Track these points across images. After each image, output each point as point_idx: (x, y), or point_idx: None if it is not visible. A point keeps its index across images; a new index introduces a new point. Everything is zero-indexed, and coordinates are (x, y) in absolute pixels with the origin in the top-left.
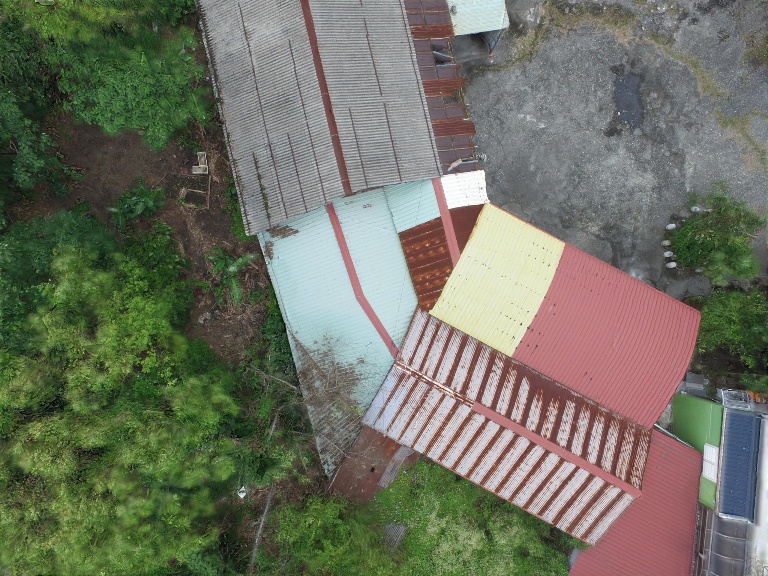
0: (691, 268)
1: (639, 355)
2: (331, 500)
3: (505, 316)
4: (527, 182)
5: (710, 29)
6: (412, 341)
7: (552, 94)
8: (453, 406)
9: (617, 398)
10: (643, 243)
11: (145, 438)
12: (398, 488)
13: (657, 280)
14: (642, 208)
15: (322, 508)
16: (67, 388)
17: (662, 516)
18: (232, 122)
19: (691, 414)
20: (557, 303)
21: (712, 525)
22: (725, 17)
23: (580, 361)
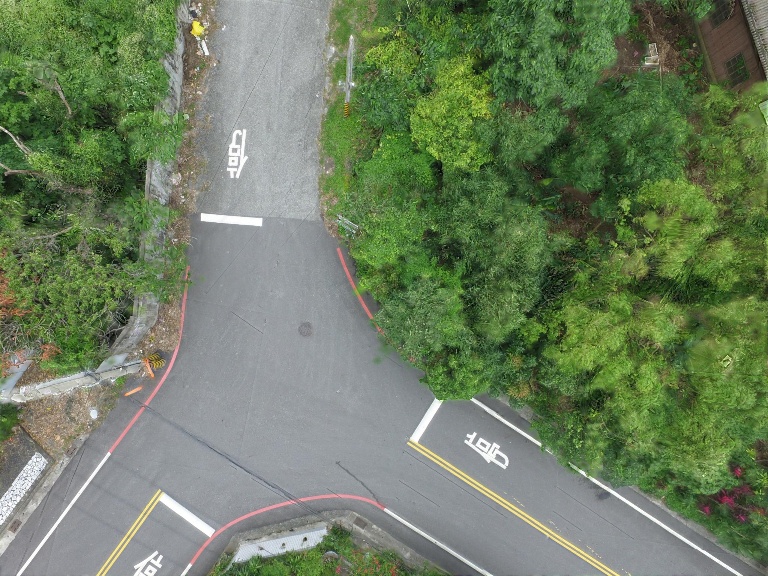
0: None
1: None
2: None
3: None
4: None
5: None
6: None
7: None
8: None
9: None
10: None
11: None
12: None
13: None
14: None
15: None
16: None
17: None
18: None
19: None
20: None
21: None
22: None
23: None
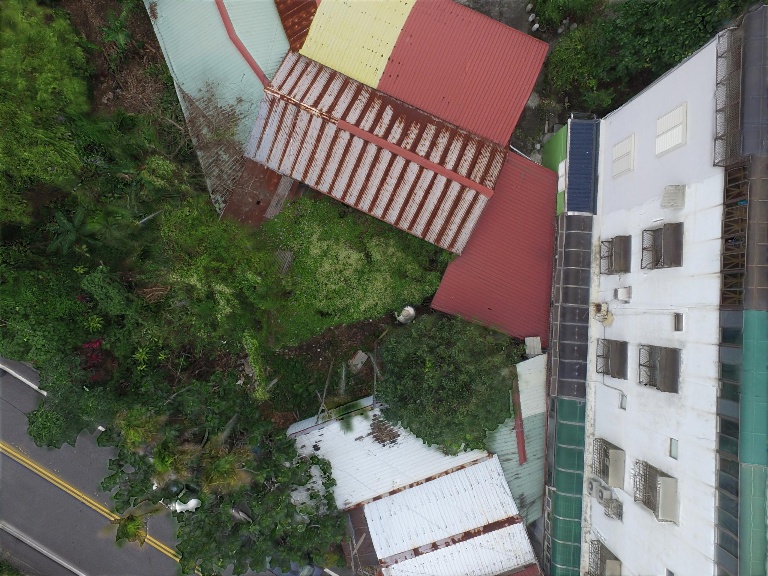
0: (553, 28)
1: (490, 77)
2: None
3: (367, 49)
4: None
5: None
6: (282, 73)
7: None
8: (321, 126)
9: (473, 119)
10: (509, 11)
11: (46, 177)
12: (283, 219)
13: None
14: None
15: None
16: None
17: (524, 231)
18: None
19: (552, 149)
20: (413, 34)
21: (564, 228)
22: None
23: (437, 86)
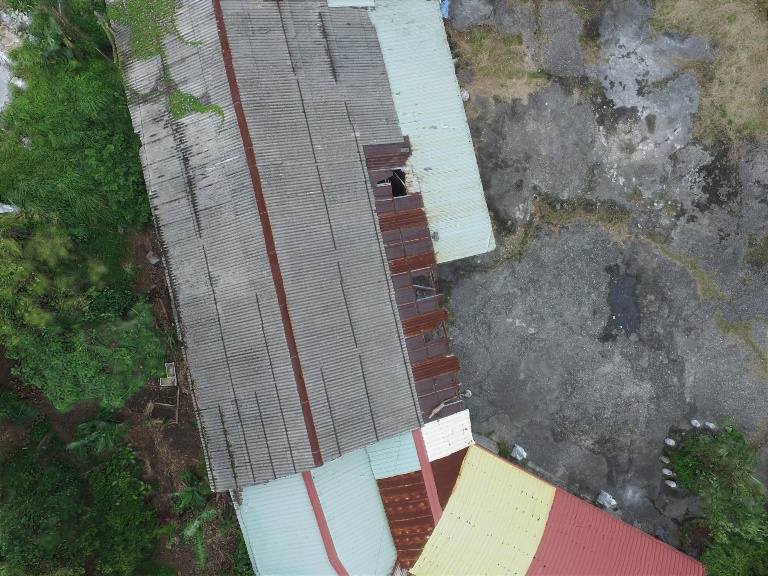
0: (692, 488)
1: None
2: None
3: None
4: (516, 392)
5: (710, 227)
6: None
7: (543, 297)
8: None
9: None
10: (640, 457)
11: None
12: None
13: (655, 497)
14: (639, 420)
15: None
16: None
17: None
18: (196, 369)
19: None
20: (547, 564)
21: None
22: (726, 214)
23: None
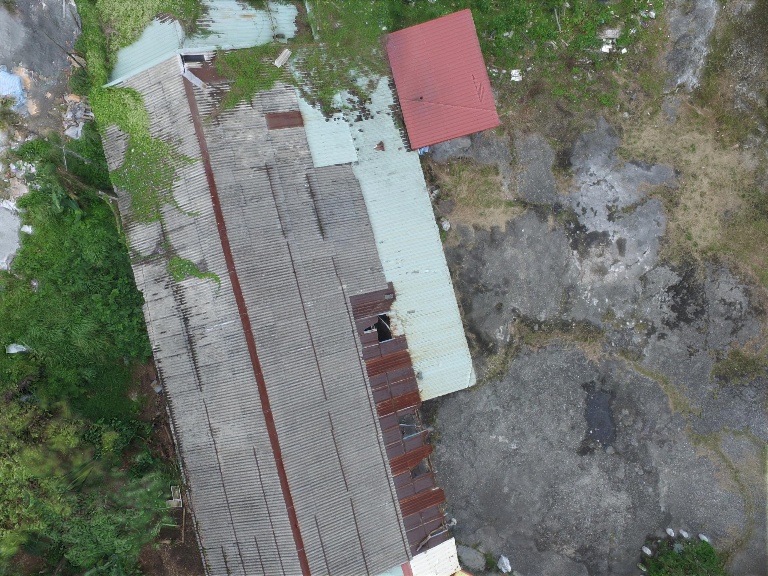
0: None
1: None
2: None
3: None
4: (501, 504)
5: (680, 344)
6: None
7: (524, 414)
8: None
9: None
10: (619, 564)
11: None
12: None
13: None
14: (617, 529)
15: None
16: None
17: None
18: (200, 512)
19: None
20: None
21: None
22: (695, 331)
23: None
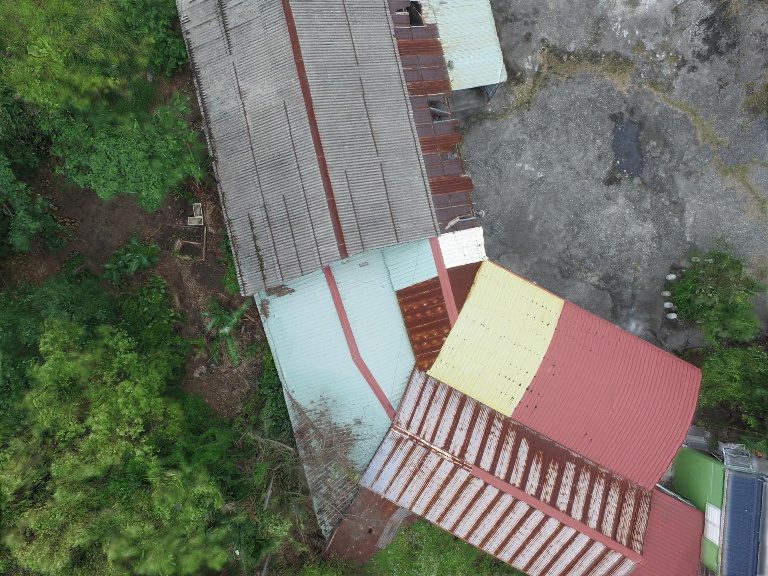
0: (691, 319)
1: (639, 416)
2: (328, 563)
3: (504, 377)
4: (526, 232)
5: (710, 76)
6: (410, 403)
7: (550, 143)
8: (451, 470)
9: (617, 459)
10: (643, 293)
11: (139, 502)
12: (396, 549)
13: (657, 331)
14: (642, 258)
15: (319, 573)
16: (59, 462)
17: None
18: (227, 181)
19: (692, 470)
20: (556, 363)
21: None
22: (725, 64)
23: (580, 422)
